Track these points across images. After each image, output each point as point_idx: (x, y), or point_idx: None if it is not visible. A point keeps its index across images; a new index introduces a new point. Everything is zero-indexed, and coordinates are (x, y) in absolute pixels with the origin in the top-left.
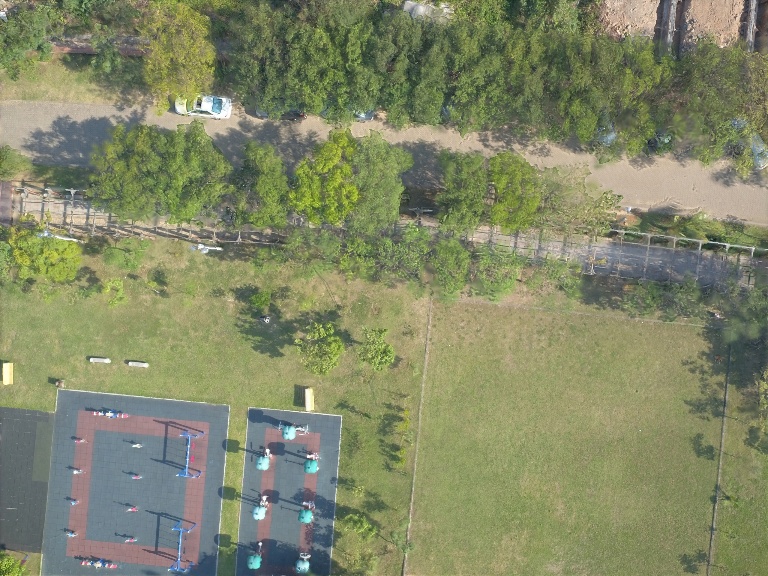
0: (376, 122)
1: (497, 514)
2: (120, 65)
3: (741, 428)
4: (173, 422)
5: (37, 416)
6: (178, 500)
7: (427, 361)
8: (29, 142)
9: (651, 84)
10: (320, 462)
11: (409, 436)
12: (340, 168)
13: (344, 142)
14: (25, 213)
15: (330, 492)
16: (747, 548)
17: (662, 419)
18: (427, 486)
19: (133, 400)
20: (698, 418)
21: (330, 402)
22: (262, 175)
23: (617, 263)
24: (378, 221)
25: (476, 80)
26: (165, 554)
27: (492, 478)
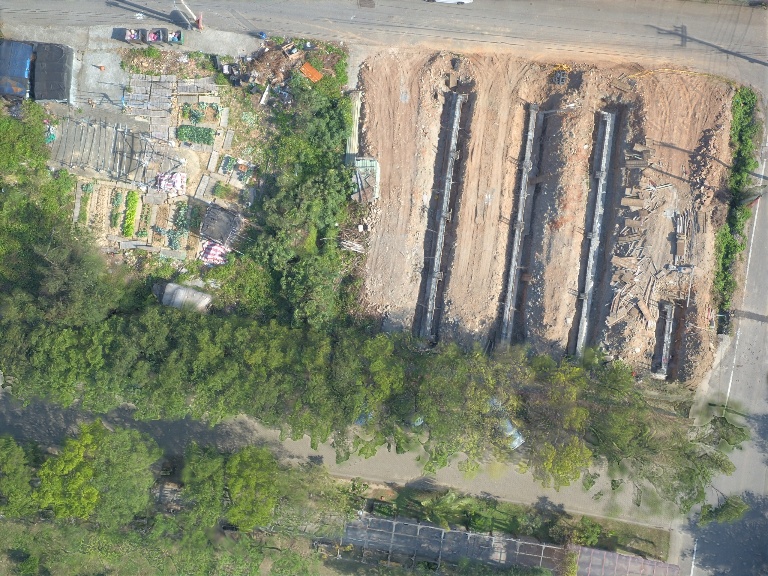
0: None
1: None
2: None
3: None
4: None
5: None
6: None
7: None
8: None
9: (381, 394)
10: None
11: None
12: (79, 471)
13: (88, 440)
14: None
15: None
16: None
17: None
18: None
19: None
20: None
21: None
22: (3, 476)
23: (362, 549)
24: (121, 516)
25: (213, 387)
26: None
27: None
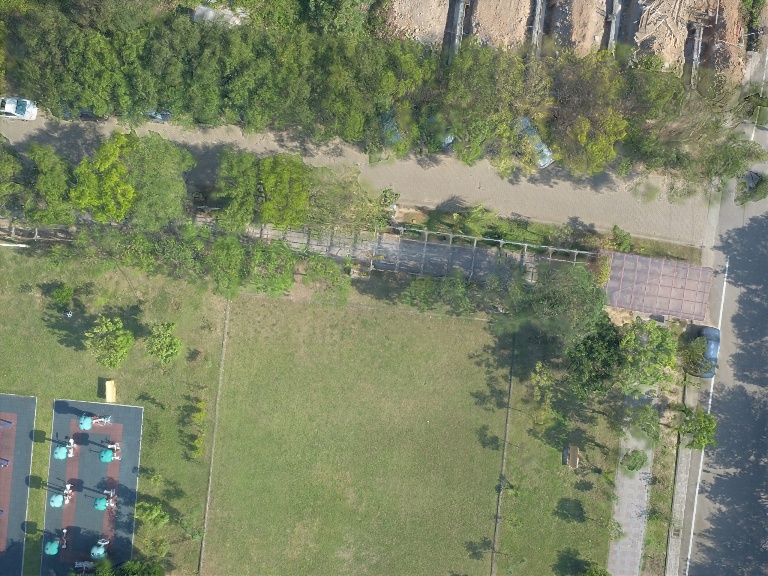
0: None
1: (290, 502)
2: None
3: (525, 419)
4: None
5: None
6: None
7: (224, 354)
8: None
9: (413, 86)
10: (122, 452)
11: (202, 427)
12: (115, 167)
13: (123, 142)
14: None
15: (132, 481)
16: (531, 536)
17: (449, 410)
18: (224, 475)
19: None
20: (484, 410)
21: (132, 394)
22: (41, 174)
23: (395, 259)
24: (156, 219)
25: (246, 83)
26: None
27: (286, 467)
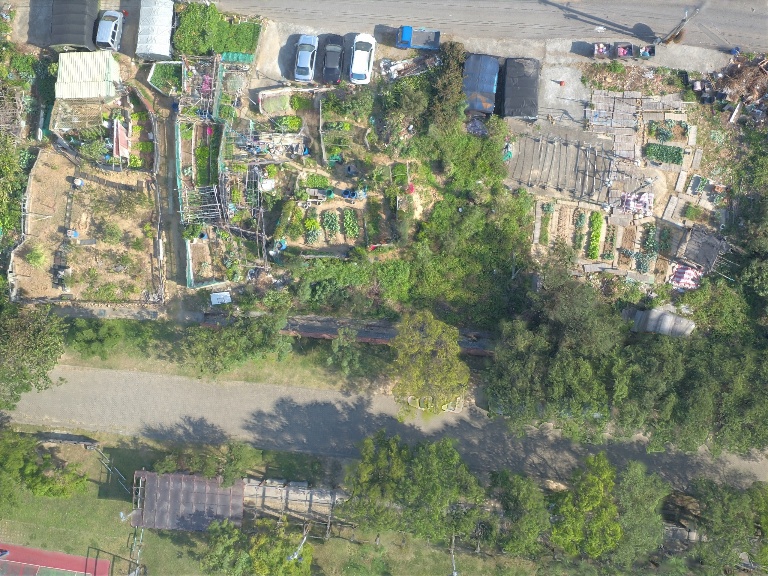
0: None
1: None
2: (357, 364)
3: None
4: None
5: None
6: None
7: None
8: (251, 425)
9: None
10: None
11: None
12: (605, 507)
13: (604, 475)
14: (246, 497)
15: None
16: None
17: None
18: None
19: None
20: None
21: None
22: (525, 512)
23: None
24: (636, 553)
25: (744, 420)
26: None
27: None
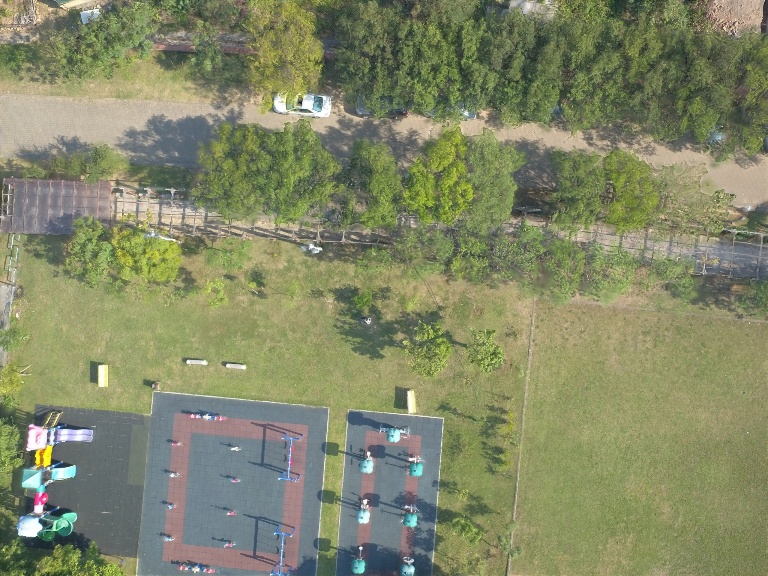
0: (478, 120)
1: (602, 517)
2: (221, 63)
3: None
4: (271, 425)
5: (132, 419)
6: (277, 504)
7: (530, 362)
8: (123, 141)
9: None
10: None
11: (515, 439)
12: (456, 167)
13: (457, 140)
14: (119, 213)
15: (432, 495)
16: None
17: None
18: (531, 489)
19: (230, 402)
20: None
21: (432, 404)
22: (376, 174)
23: (729, 263)
24: (491, 221)
25: (593, 77)
26: (263, 558)
27: (597, 481)
